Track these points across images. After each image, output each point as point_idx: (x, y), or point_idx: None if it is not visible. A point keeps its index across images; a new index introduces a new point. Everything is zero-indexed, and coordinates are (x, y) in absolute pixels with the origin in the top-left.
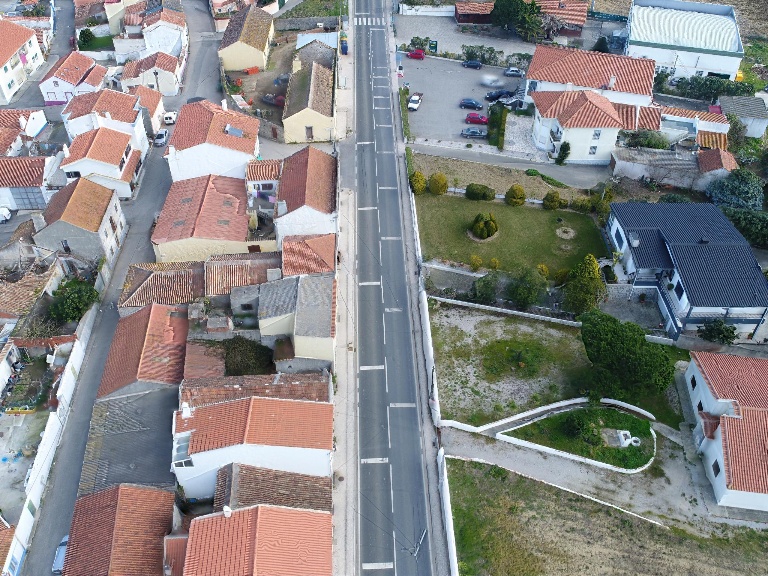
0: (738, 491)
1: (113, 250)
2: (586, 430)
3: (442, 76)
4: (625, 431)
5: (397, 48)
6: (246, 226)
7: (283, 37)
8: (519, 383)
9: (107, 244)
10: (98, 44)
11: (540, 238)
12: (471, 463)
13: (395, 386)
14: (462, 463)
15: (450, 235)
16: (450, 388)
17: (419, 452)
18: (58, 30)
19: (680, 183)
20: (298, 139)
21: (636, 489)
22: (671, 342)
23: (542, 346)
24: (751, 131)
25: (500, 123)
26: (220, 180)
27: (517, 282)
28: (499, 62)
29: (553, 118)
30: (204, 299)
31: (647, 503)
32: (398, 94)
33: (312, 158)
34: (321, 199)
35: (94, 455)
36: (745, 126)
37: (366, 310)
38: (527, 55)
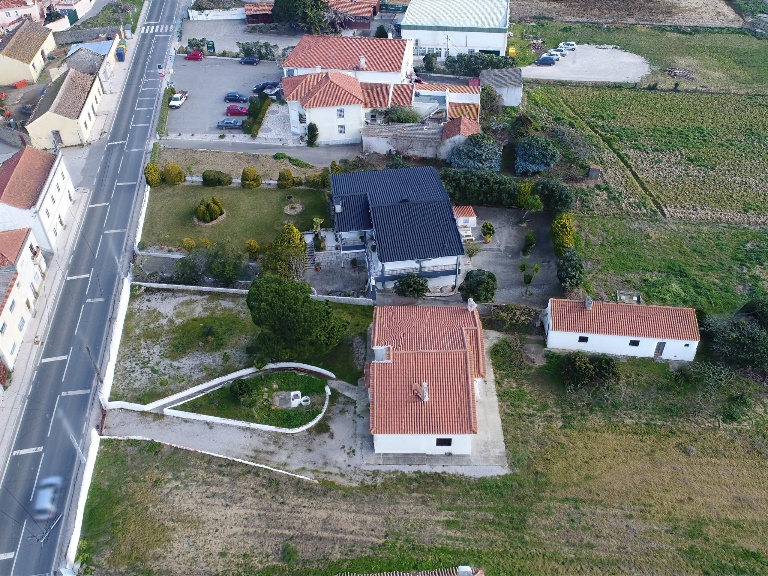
0: (383, 435)
1: None
2: (255, 395)
3: (216, 74)
4: (296, 392)
5: (176, 51)
6: None
7: (60, 50)
8: (203, 357)
9: None
10: None
11: (266, 216)
12: (128, 441)
13: (73, 374)
14: (118, 442)
15: (175, 222)
16: (129, 370)
17: (79, 437)
18: None
19: (424, 153)
20: (47, 145)
21: (296, 447)
22: (371, 302)
23: (238, 319)
24: (508, 100)
25: (258, 112)
26: None
27: (212, 258)
28: (276, 56)
29: (296, 100)
30: None
31: (303, 460)
32: None
33: (26, 157)
34: (24, 196)
35: None
36: (499, 95)
37: (66, 303)
38: None
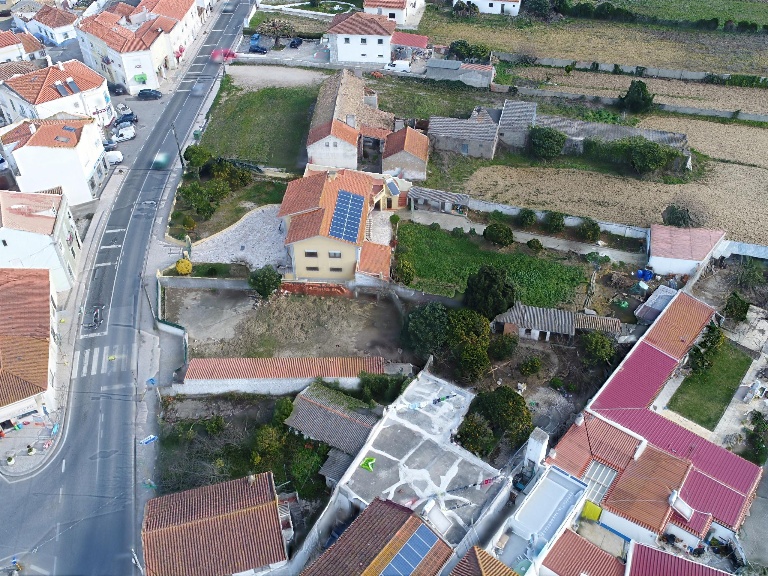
0: (368, 9)
1: None
2: (320, 5)
3: None
4: (337, 5)
5: None
6: None
7: None
8: None
9: None
10: None
11: None
12: (267, 12)
13: None
14: (263, 12)
15: None
16: None
17: (248, 12)
18: None
19: None
20: None
21: None
22: None
23: None
24: None
25: None
26: None
27: None
28: None
29: None
30: None
31: None
32: None
33: None
34: None
35: (111, 5)
36: None
37: None
38: None
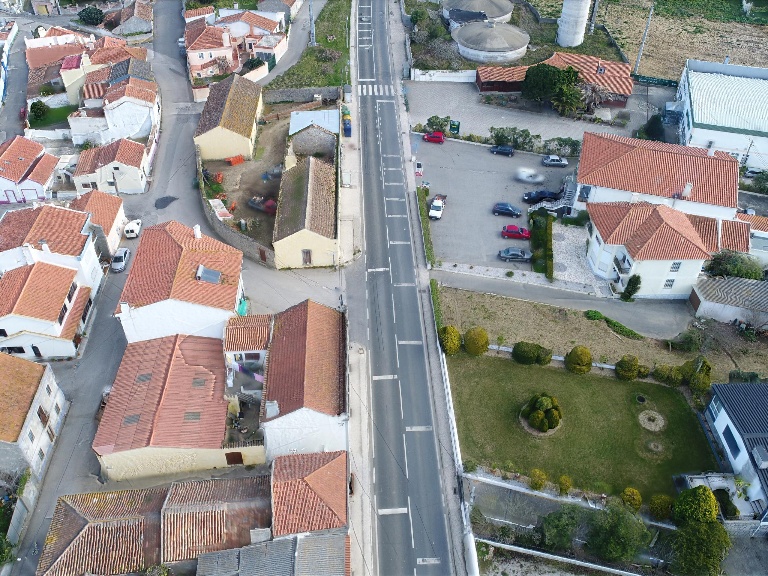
0: None
1: (43, 451)
2: None
3: (467, 167)
4: None
5: (411, 128)
6: (223, 420)
7: (273, 114)
8: None
9: (33, 449)
10: (53, 118)
11: (618, 430)
12: None
13: None
14: None
15: (497, 425)
16: None
17: None
18: (8, 97)
19: None
20: (292, 264)
21: None
22: None
23: None
24: None
25: (546, 240)
26: (190, 343)
27: (605, 533)
28: (535, 147)
29: (619, 245)
30: (159, 570)
31: None
32: (415, 195)
33: (312, 320)
34: (325, 390)
35: None
36: None
37: (390, 562)
38: (570, 141)
